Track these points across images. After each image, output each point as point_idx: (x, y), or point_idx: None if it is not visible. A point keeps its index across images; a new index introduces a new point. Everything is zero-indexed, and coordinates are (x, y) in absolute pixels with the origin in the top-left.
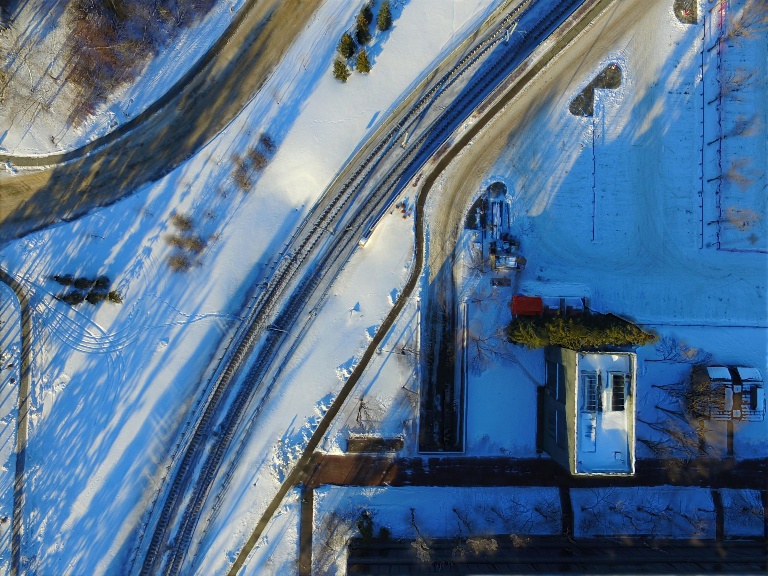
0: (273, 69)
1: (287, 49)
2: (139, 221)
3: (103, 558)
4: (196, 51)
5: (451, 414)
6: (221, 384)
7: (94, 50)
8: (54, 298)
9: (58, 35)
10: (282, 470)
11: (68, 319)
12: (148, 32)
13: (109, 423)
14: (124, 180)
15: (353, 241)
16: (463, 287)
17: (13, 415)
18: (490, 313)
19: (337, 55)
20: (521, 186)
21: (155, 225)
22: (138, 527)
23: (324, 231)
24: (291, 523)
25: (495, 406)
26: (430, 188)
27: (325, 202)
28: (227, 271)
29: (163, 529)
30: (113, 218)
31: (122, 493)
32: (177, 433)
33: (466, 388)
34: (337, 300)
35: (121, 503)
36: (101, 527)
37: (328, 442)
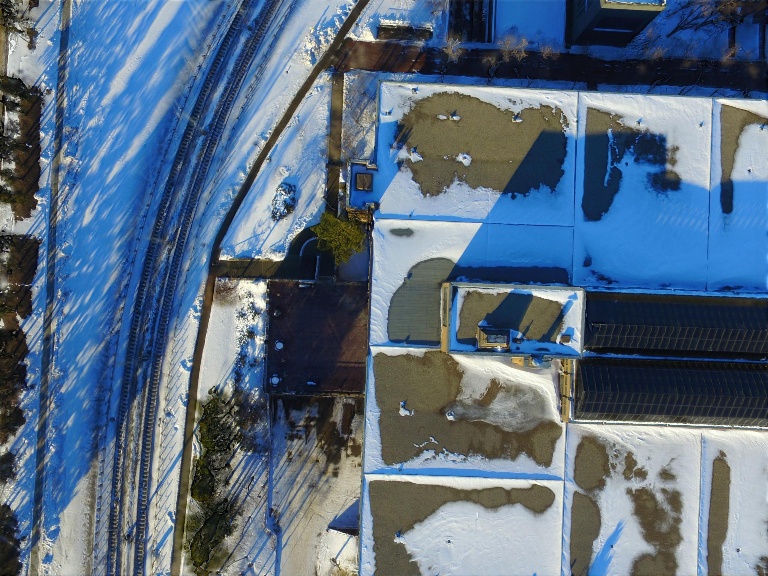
0: None
1: None
2: None
3: (141, 132)
4: None
5: (480, 24)
6: None
7: None
8: None
9: None
10: (314, 53)
11: None
12: None
13: (148, 5)
14: None
15: None
16: None
17: None
18: None
19: None
20: None
21: None
22: (174, 109)
23: None
24: (322, 102)
25: None
26: None
27: None
28: None
29: (198, 115)
30: None
31: (160, 72)
32: (213, 24)
33: None
34: None
35: (159, 82)
36: (140, 103)
37: (359, 28)
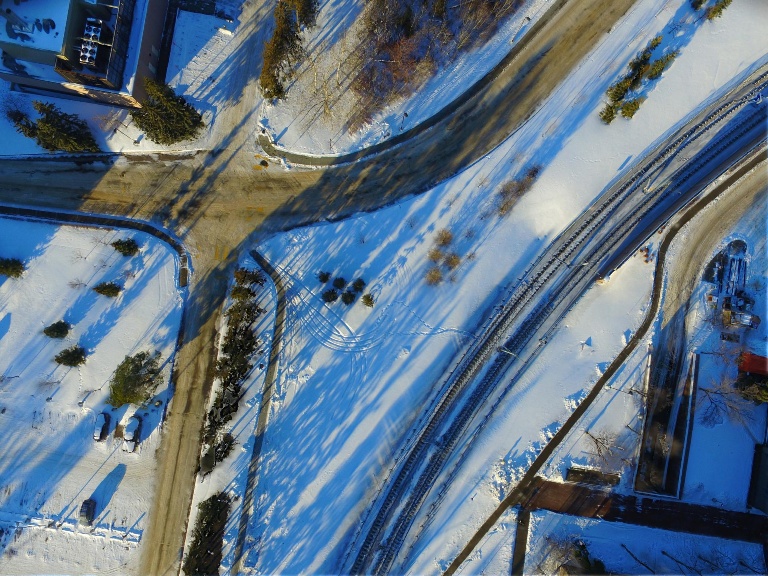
0: (542, 102)
1: (560, 85)
2: (398, 231)
3: (323, 548)
4: (472, 76)
5: (660, 457)
6: (448, 397)
7: (378, 62)
8: (310, 293)
9: (347, 43)
10: (503, 489)
11: (320, 315)
12: (431, 52)
13: (345, 420)
14: (389, 189)
15: (587, 276)
16: (693, 337)
17: (258, 399)
18: (717, 366)
19: (605, 97)
20: (760, 247)
21: (413, 237)
22: (357, 523)
23: (562, 263)
24: (506, 542)
25: (713, 457)
26: (674, 237)
27: (565, 235)
28: (472, 290)
29: (378, 528)
30: (374, 224)
31: (348, 489)
32: (403, 438)
33: (688, 436)
34: (568, 332)
35: (346, 498)
36: (325, 518)
37: (550, 469)
